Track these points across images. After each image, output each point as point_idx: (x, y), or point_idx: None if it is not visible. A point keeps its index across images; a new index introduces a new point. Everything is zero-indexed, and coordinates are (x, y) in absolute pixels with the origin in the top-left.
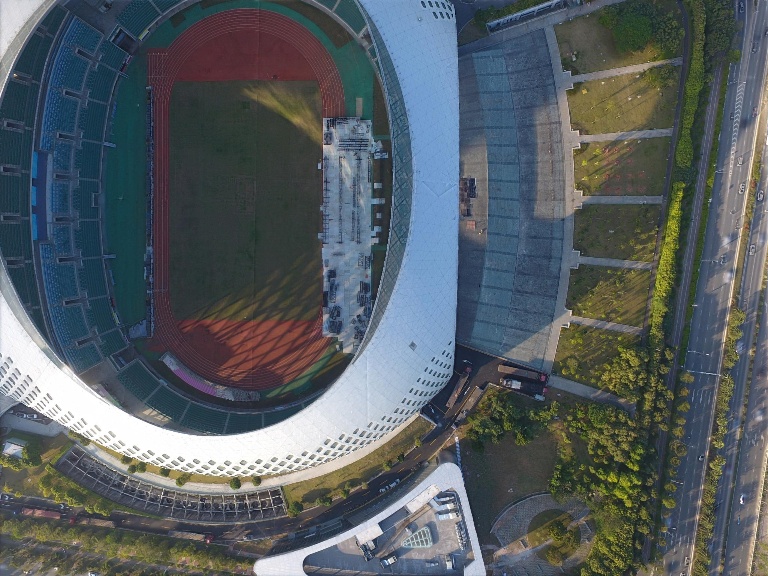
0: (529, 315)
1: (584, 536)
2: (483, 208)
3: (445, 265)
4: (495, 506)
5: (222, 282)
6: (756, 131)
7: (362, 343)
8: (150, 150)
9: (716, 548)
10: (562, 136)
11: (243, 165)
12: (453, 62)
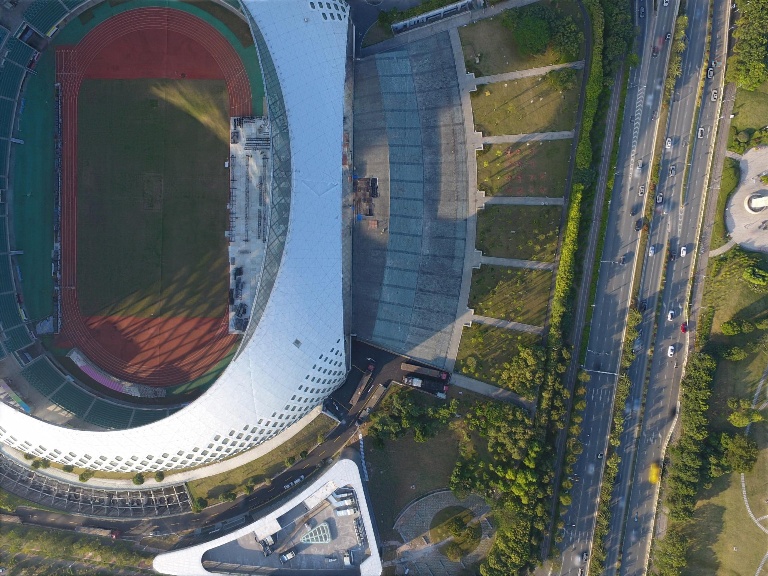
0: (432, 314)
1: (485, 532)
2: (385, 208)
3: (328, 264)
4: (398, 502)
5: (129, 279)
6: (656, 134)
7: (243, 340)
8: (58, 147)
9: (614, 544)
10: (465, 137)
11: (151, 163)
12: (340, 63)
